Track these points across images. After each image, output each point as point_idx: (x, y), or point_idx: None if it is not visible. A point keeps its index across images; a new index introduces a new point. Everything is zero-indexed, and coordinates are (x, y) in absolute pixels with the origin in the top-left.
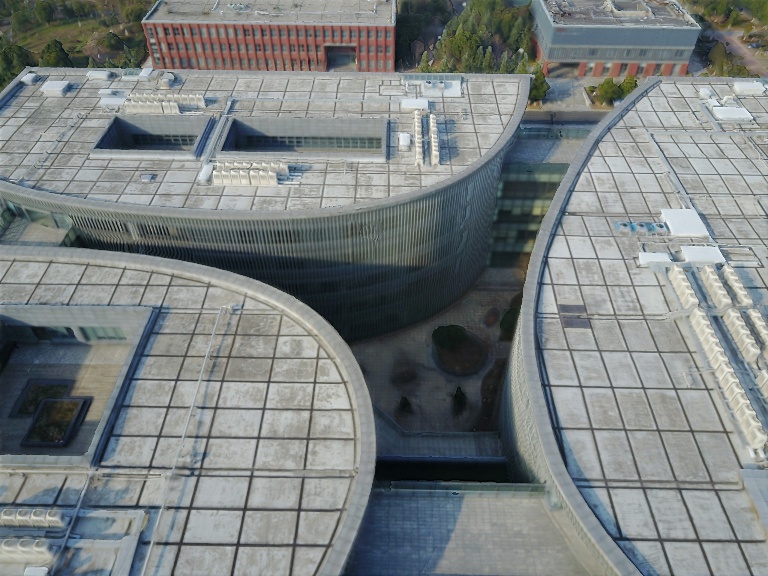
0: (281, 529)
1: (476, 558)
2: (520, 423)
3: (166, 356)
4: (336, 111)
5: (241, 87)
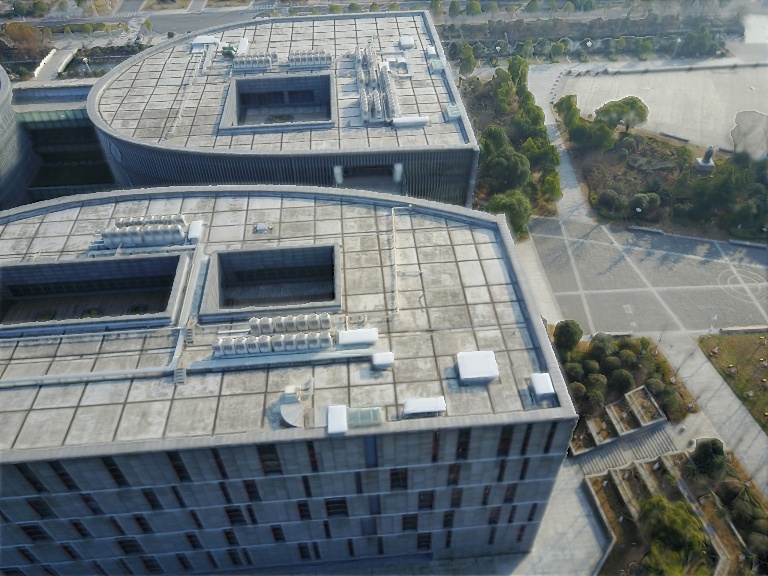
0: (143, 75)
1: (66, 106)
2: (7, 152)
3: (207, 115)
4: (6, 364)
5: (157, 410)
